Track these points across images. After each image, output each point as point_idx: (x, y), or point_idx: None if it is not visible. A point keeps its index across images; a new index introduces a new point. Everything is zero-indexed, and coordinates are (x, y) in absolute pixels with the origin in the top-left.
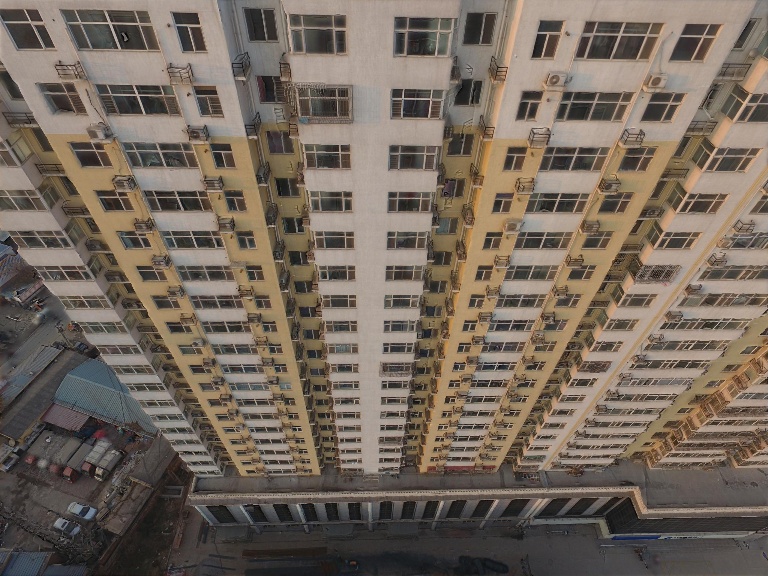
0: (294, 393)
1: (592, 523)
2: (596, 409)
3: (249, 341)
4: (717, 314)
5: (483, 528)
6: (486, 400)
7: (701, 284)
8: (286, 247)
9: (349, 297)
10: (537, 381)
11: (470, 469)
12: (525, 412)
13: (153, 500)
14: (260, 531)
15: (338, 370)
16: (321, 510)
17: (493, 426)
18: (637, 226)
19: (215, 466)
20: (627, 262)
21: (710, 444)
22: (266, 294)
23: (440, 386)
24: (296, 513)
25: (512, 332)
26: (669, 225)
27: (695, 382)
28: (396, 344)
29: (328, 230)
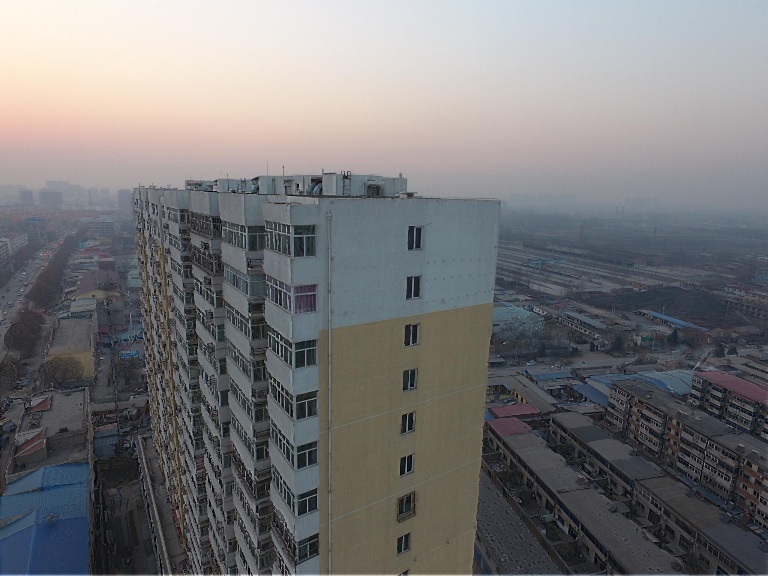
0: None
1: None
2: None
3: None
4: None
5: None
6: None
7: None
8: None
9: None
10: None
11: None
12: None
13: None
14: None
15: None
16: None
17: None
18: None
19: None
20: None
21: None
22: None
23: None
24: None
25: None
26: None
27: None
28: None
29: None
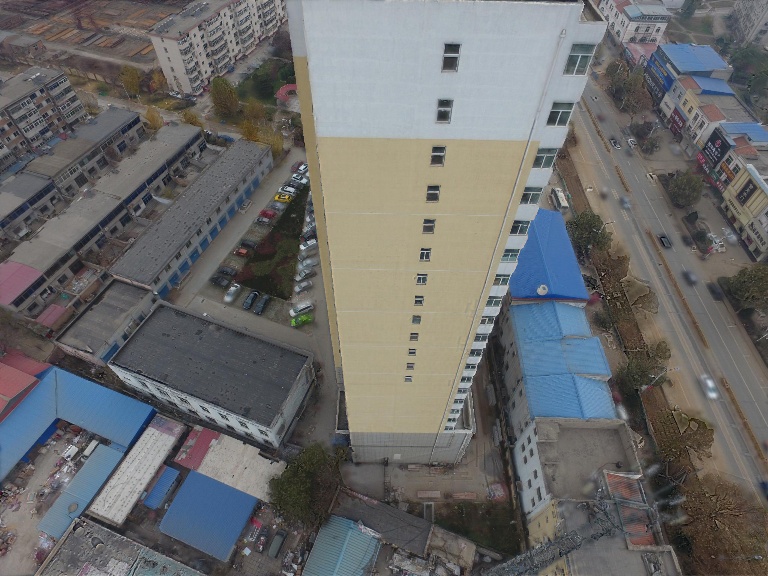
0: None
1: None
2: None
3: None
4: None
5: None
6: None
7: None
8: None
9: None
10: None
11: None
12: None
13: None
14: None
15: None
16: None
17: None
18: None
19: None
20: None
21: None
22: None
23: None
24: None
25: None
26: None
27: None
28: None
29: None
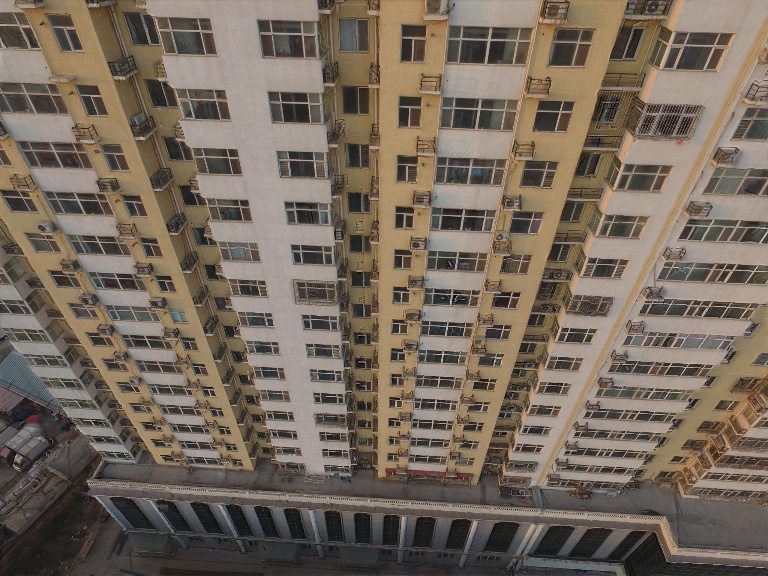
0: (192, 329)
1: (606, 571)
2: (598, 384)
3: (114, 231)
4: (765, 211)
5: (464, 567)
6: (447, 360)
7: (737, 147)
8: (140, 71)
9: (229, 154)
10: (512, 329)
11: (441, 477)
12: (501, 384)
13: (69, 497)
14: (187, 546)
15: (241, 292)
16: (253, 518)
17: (461, 404)
18: (634, 45)
19: (122, 445)
20: (624, 115)
21: (764, 461)
22: (116, 143)
23: (380, 329)
24: (223, 521)
25: (465, 233)
26: (680, 15)
27: (738, 354)
28: (309, 249)
29: (173, 15)
